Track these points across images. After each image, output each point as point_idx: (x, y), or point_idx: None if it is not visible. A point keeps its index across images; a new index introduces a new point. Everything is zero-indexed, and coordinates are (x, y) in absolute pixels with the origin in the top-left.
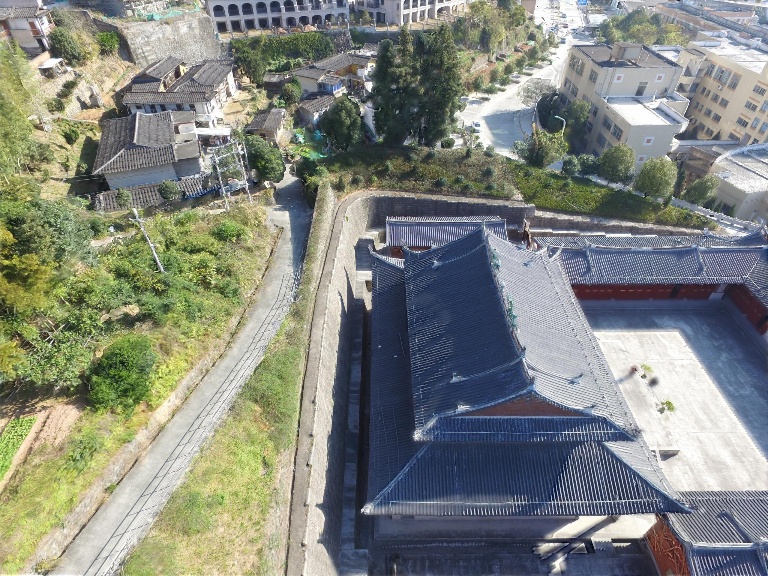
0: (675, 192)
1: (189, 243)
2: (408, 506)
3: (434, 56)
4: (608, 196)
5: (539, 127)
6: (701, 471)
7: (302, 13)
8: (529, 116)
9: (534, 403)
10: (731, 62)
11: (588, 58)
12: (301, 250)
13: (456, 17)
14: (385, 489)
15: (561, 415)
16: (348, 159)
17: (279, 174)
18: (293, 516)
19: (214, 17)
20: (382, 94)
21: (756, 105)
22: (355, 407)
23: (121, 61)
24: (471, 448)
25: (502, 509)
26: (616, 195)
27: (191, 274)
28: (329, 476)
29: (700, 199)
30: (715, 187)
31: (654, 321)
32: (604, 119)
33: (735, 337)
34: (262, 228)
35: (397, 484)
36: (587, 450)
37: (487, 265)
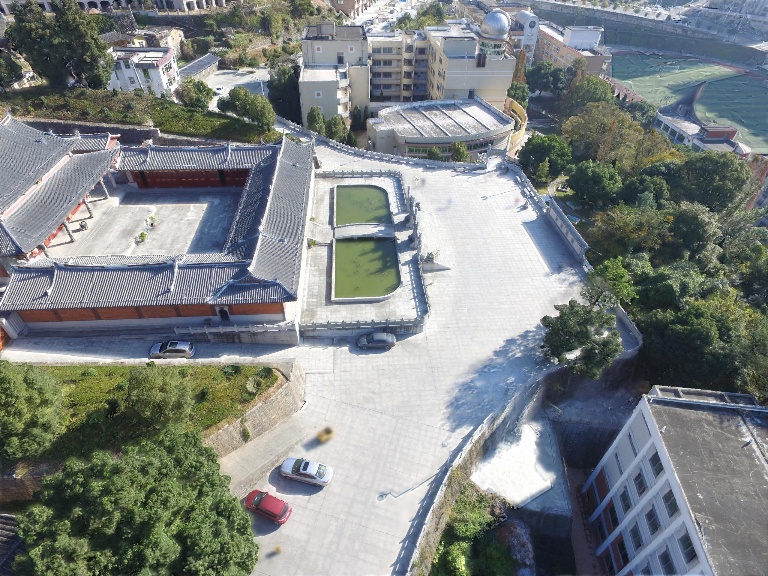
0: None
1: None
2: None
3: None
4: (223, 124)
5: None
6: None
7: None
8: None
9: None
10: (434, 40)
11: None
12: None
13: (244, 6)
14: None
15: None
16: (7, 93)
17: None
18: None
19: (3, 0)
20: (23, 43)
21: (440, 72)
22: None
23: None
24: None
25: None
26: (231, 123)
27: None
28: None
29: (332, 134)
30: (340, 124)
31: (198, 198)
32: None
33: None
34: None
35: None
36: None
37: None
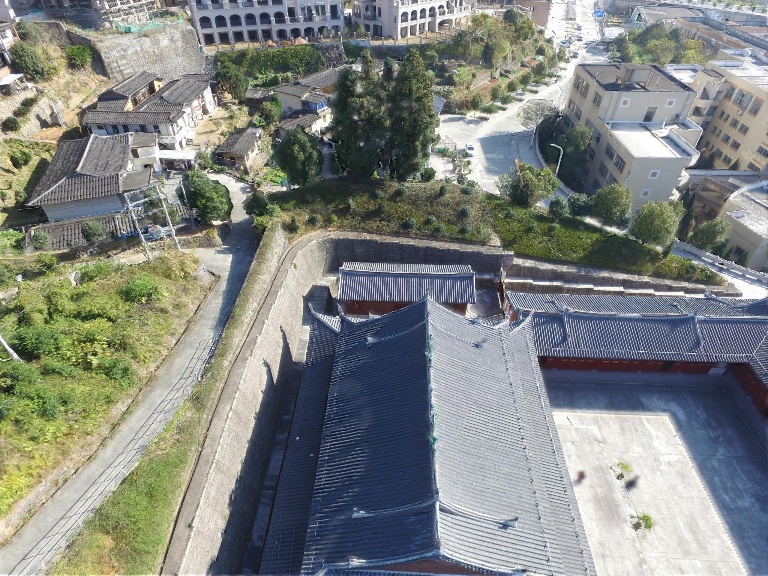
0: (682, 231)
1: (81, 308)
2: None
3: (402, 84)
4: (599, 243)
5: (537, 152)
6: None
7: (293, 25)
8: (528, 139)
9: (446, 564)
10: (753, 85)
11: (592, 79)
12: (230, 308)
13: (458, 30)
14: None
15: (485, 575)
16: (305, 196)
17: (224, 213)
18: None
19: (200, 29)
20: (342, 126)
21: None
22: (265, 509)
23: (94, 75)
24: None
25: None
26: (608, 242)
27: (69, 352)
28: None
29: (708, 244)
30: (726, 231)
31: (640, 400)
32: (607, 147)
33: (736, 426)
34: (191, 279)
35: None
36: None
37: (424, 351)
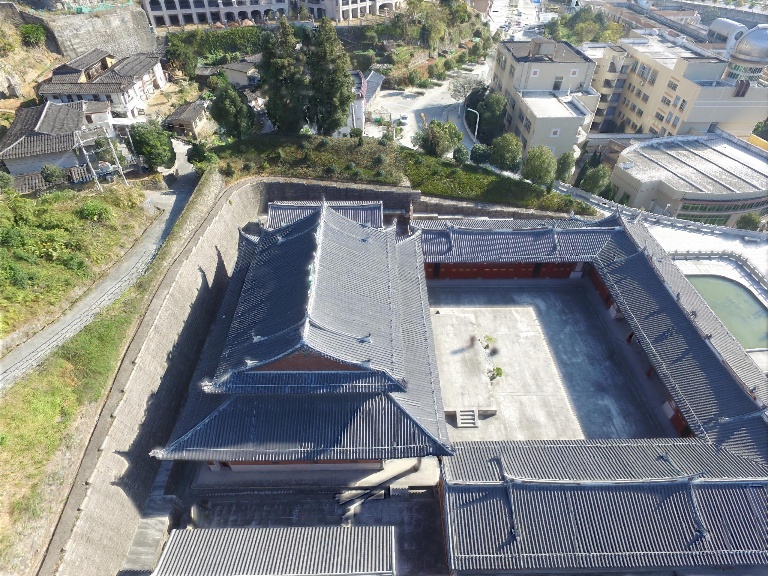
0: None
1: (42, 220)
2: (202, 452)
3: (319, 48)
4: (493, 183)
5: (464, 120)
6: (514, 429)
7: (240, 8)
8: (458, 110)
9: (313, 357)
10: (650, 59)
11: (508, 53)
12: (171, 230)
13: (398, 13)
14: (181, 437)
15: (344, 370)
16: (240, 146)
17: (168, 160)
18: (85, 459)
19: (151, 11)
20: (268, 84)
21: (670, 100)
22: None
23: (49, 53)
24: (271, 402)
25: (289, 455)
26: (502, 182)
27: (33, 247)
28: (145, 430)
29: (594, 187)
30: (607, 176)
31: (513, 298)
32: (519, 112)
33: (584, 312)
34: (138, 209)
35: (195, 433)
36: (377, 403)
37: None
